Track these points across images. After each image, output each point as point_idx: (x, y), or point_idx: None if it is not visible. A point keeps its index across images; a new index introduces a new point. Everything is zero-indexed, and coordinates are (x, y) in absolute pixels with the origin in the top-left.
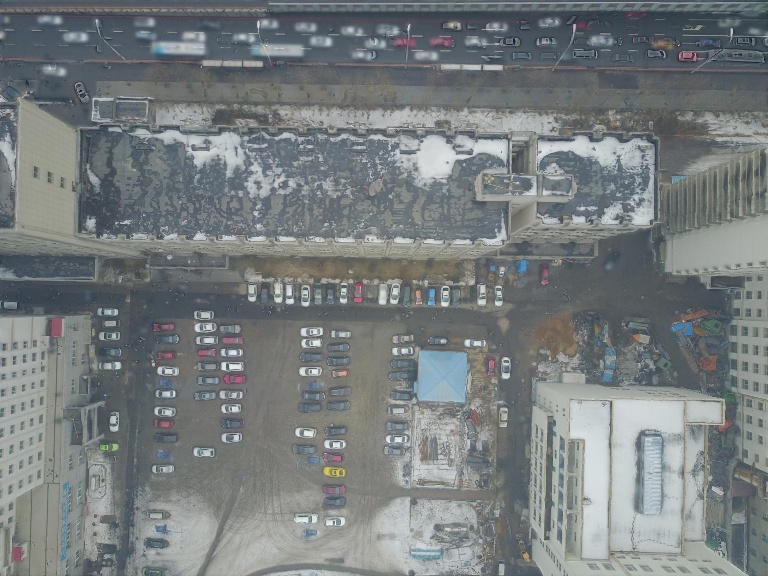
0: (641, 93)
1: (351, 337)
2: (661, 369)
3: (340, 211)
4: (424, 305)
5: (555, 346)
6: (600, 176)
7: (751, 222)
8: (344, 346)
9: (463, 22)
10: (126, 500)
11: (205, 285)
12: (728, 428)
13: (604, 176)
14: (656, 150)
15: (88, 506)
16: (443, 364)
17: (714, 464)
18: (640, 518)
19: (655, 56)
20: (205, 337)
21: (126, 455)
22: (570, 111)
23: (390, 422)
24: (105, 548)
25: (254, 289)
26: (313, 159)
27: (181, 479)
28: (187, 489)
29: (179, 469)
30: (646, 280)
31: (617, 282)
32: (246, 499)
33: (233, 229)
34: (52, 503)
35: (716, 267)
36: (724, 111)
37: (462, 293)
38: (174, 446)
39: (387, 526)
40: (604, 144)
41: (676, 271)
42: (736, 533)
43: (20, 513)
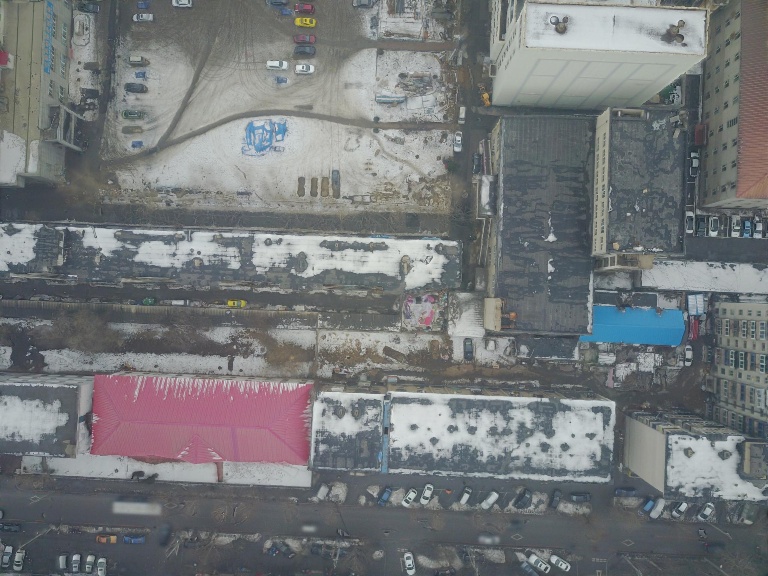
0: None
1: None
2: None
3: None
4: None
5: None
6: None
7: None
8: None
9: None
10: (108, 48)
11: None
12: None
13: None
14: None
15: (72, 51)
16: None
17: None
18: None
19: None
20: None
21: (109, 6)
22: None
23: None
24: (88, 93)
25: None
26: None
27: (160, 30)
28: (166, 39)
29: (158, 20)
30: None
31: None
32: (221, 49)
33: None
34: (37, 21)
35: None
36: None
37: None
38: None
39: (354, 75)
40: None
41: None
42: (692, 84)
43: (7, 29)
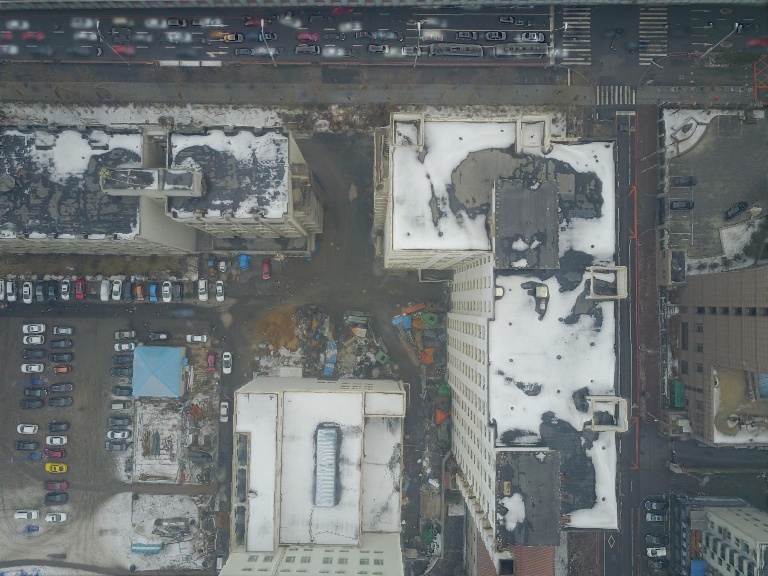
0: (364, 88)
1: (74, 333)
2: (379, 362)
3: None
4: (147, 301)
5: (276, 340)
6: (235, 170)
7: None
8: (65, 342)
9: (188, 18)
10: None
11: None
12: (442, 420)
13: (239, 170)
14: (288, 143)
15: None
16: (154, 359)
17: (432, 456)
18: (318, 510)
19: (377, 51)
20: None
21: None
22: (293, 106)
23: (111, 418)
24: None
25: None
26: None
27: None
28: None
29: None
30: (368, 274)
31: (339, 276)
32: None
33: None
34: None
35: None
36: (446, 105)
37: (185, 289)
38: None
39: (109, 521)
40: (239, 138)
41: None
42: (455, 525)
43: None
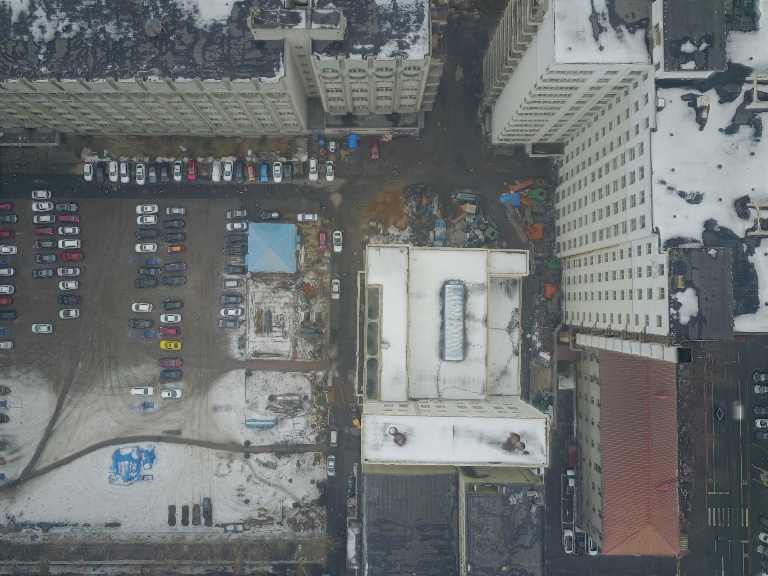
0: None
1: (186, 214)
2: (489, 238)
3: (123, 53)
4: (258, 182)
5: (386, 218)
6: (376, 15)
7: (525, 57)
8: (178, 222)
9: None
10: None
11: (43, 166)
12: (553, 293)
13: (380, 15)
14: None
15: None
16: (270, 234)
17: (542, 330)
18: (445, 366)
19: None
20: (41, 215)
21: None
22: None
23: (224, 296)
24: None
25: (89, 168)
26: (96, 3)
27: (21, 356)
28: (27, 365)
29: (19, 346)
30: (475, 153)
31: (447, 156)
32: (85, 374)
33: (19, 73)
34: None
35: (512, 116)
36: None
37: (295, 169)
38: (13, 323)
39: (223, 398)
40: None
41: (496, 138)
42: (565, 398)
43: None
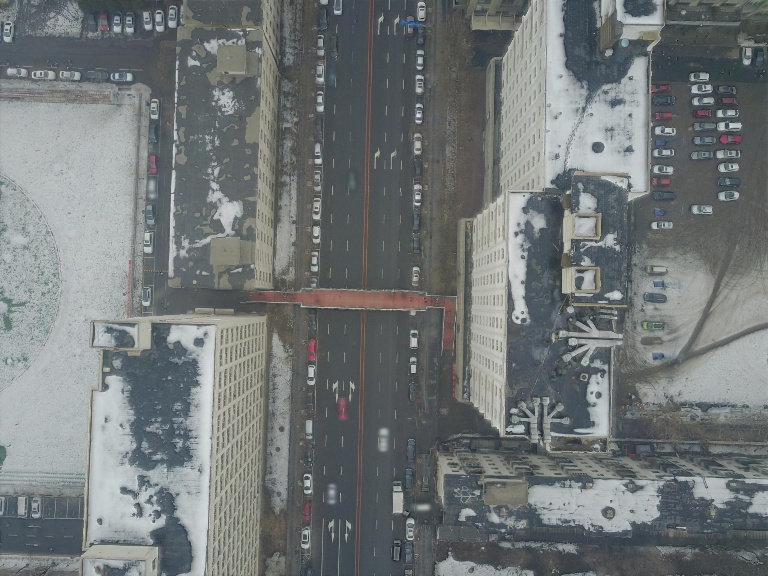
0: None
1: None
2: None
3: None
4: None
5: None
6: None
7: None
8: None
9: None
10: None
11: (698, 49)
12: None
13: None
14: None
15: None
16: None
17: None
18: None
19: None
20: (704, 97)
21: None
22: None
23: None
24: None
25: (751, 51)
26: None
27: (677, 237)
28: (684, 246)
29: (675, 227)
30: None
31: None
32: (742, 256)
33: None
34: None
35: None
36: None
37: None
38: (670, 205)
39: None
40: None
41: None
42: None
43: None
